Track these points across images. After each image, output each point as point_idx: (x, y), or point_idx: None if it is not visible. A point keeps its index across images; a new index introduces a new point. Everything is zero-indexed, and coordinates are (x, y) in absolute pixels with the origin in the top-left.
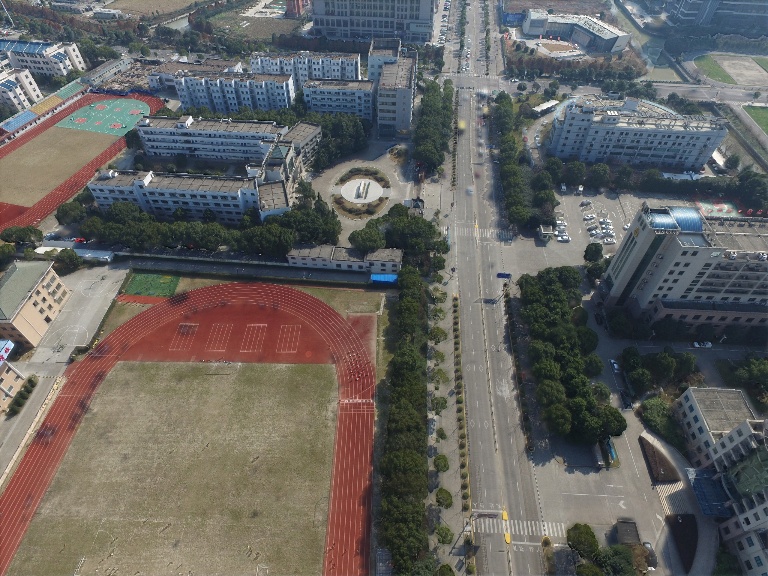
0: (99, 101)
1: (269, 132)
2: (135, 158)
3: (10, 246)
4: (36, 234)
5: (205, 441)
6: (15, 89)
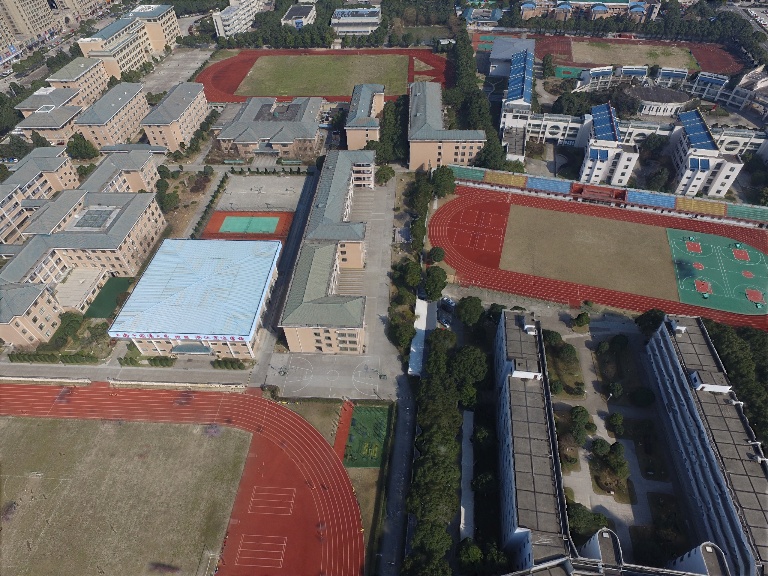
0: (755, 248)
1: (762, 559)
2: (618, 336)
3: (415, 280)
4: (433, 293)
5: (108, 568)
6: (699, 172)
